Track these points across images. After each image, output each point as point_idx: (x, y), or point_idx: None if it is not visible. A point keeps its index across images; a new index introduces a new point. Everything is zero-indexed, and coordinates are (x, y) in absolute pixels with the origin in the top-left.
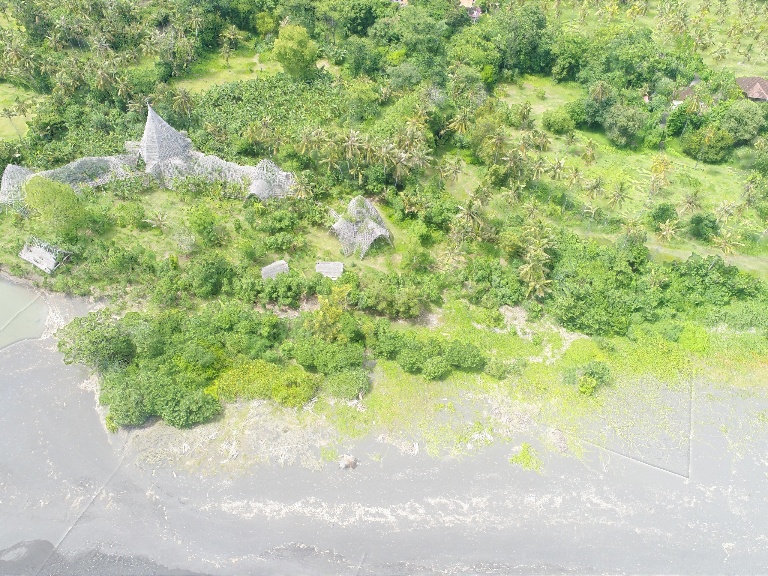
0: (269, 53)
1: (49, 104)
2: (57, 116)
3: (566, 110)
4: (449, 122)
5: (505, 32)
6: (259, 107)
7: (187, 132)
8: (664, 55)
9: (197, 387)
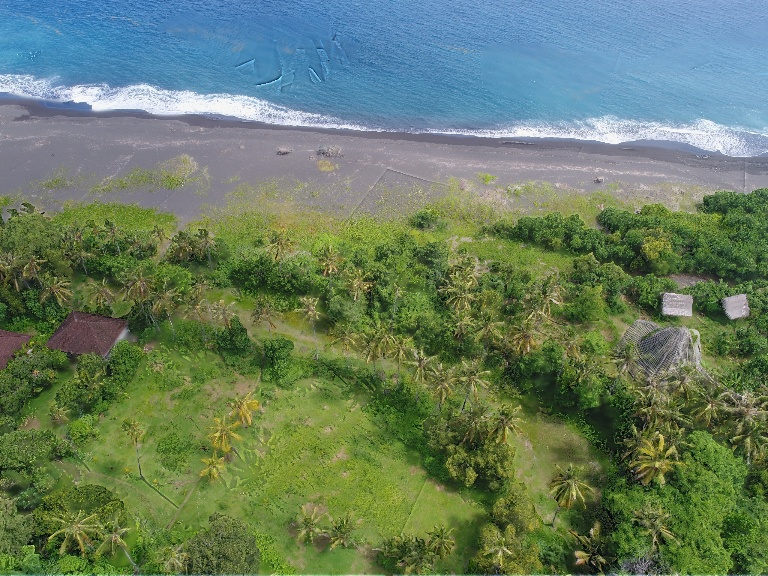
0: None
1: None
2: None
3: None
4: None
5: None
6: None
7: None
8: None
9: None
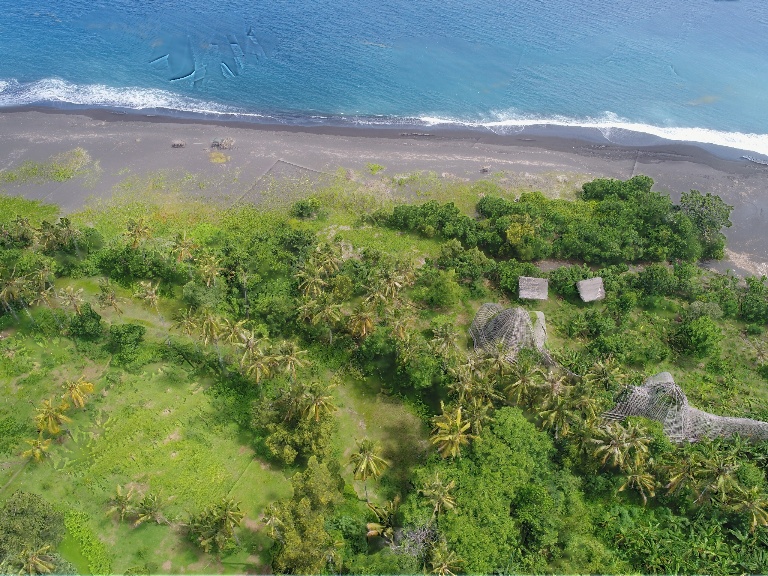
0: None
1: None
2: None
3: None
4: None
5: None
6: None
7: None
8: None
9: None
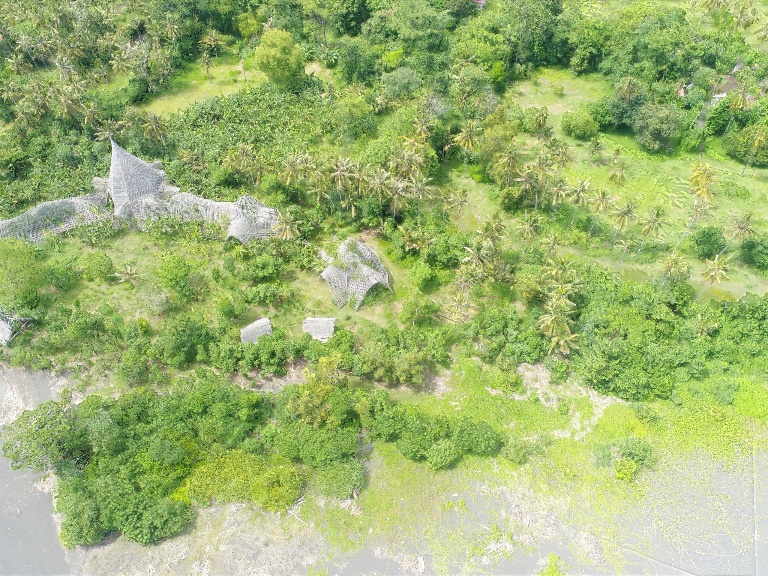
0: (254, 58)
1: (11, 138)
2: (20, 151)
3: (588, 111)
4: (454, 133)
5: (515, 21)
6: (241, 126)
7: (162, 161)
8: (700, 37)
9: (165, 490)
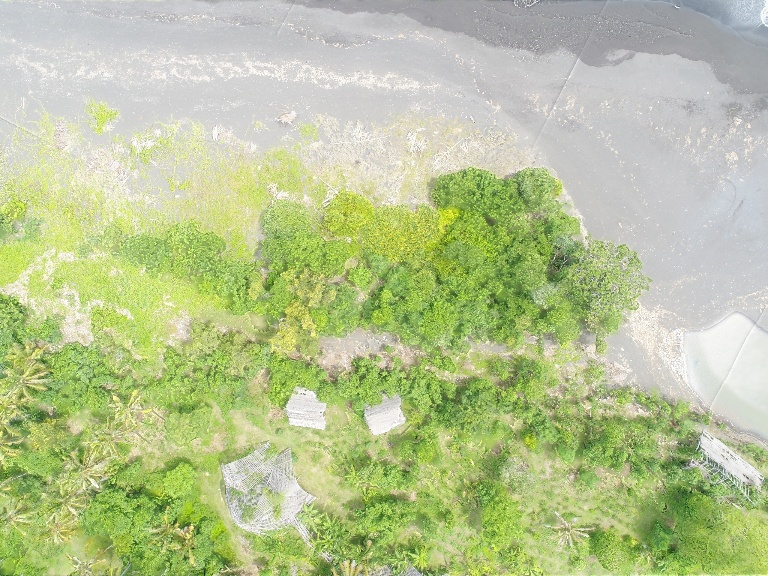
0: None
1: None
2: None
3: None
4: None
5: None
6: None
7: None
8: None
9: None
